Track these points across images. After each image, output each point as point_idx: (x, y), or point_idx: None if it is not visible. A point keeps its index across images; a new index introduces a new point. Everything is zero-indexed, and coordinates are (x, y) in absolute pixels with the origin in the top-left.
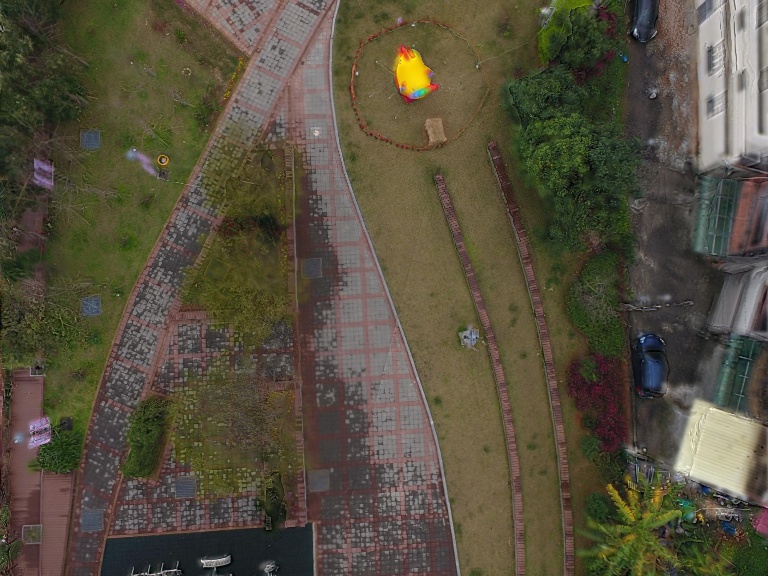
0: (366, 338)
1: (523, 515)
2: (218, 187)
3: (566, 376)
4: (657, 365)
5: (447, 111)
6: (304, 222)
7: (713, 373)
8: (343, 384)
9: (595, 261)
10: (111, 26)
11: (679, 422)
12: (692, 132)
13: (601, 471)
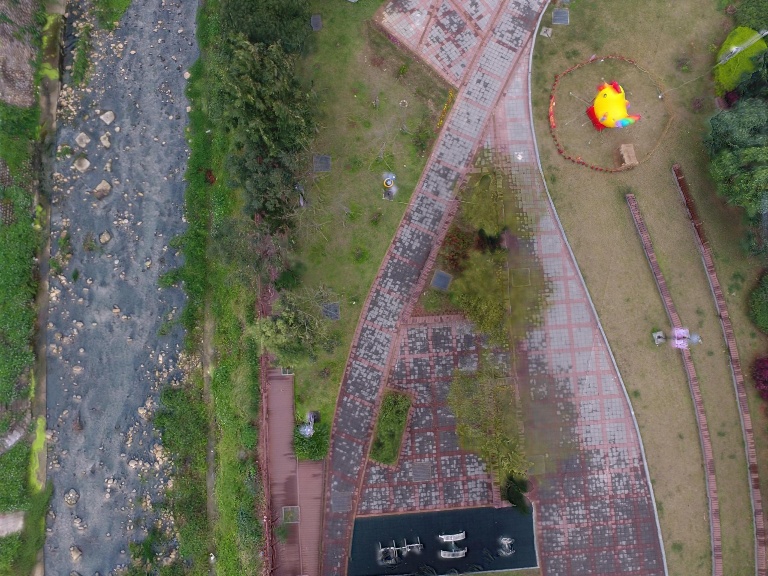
0: (571, 339)
1: (717, 494)
2: (436, 206)
3: (750, 371)
4: None
5: (635, 137)
6: (513, 237)
7: None
8: (553, 380)
9: None
10: (335, 64)
11: None
12: None
13: None
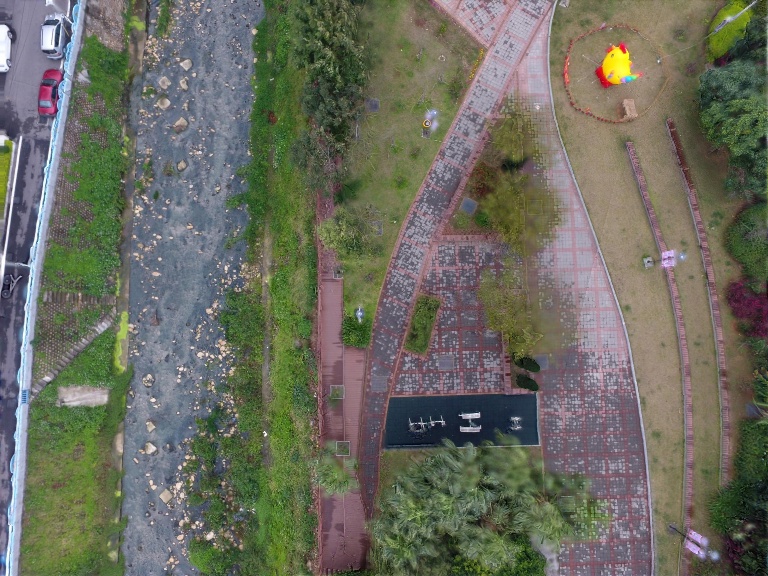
0: (575, 260)
1: (691, 391)
2: (466, 145)
3: (723, 292)
4: None
5: (636, 94)
6: (529, 173)
7: None
8: (558, 293)
9: (749, 207)
10: (385, 22)
11: None
12: None
13: (751, 360)
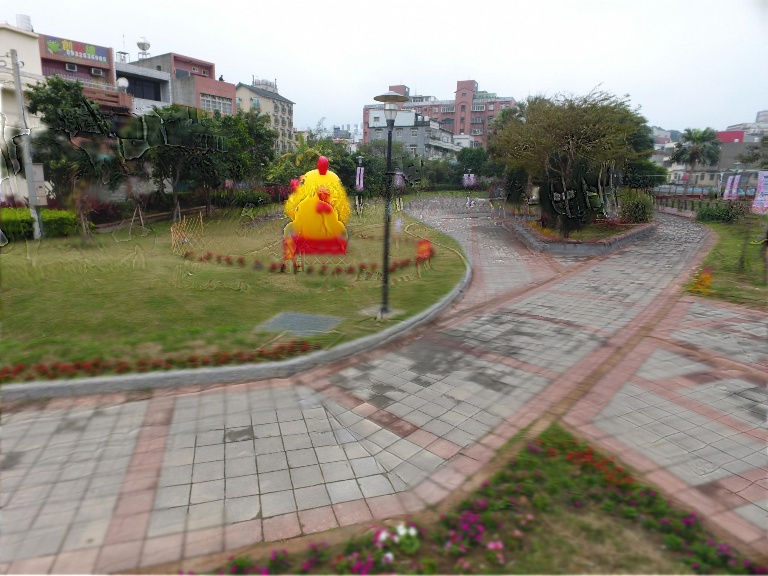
0: None
1: None
2: None
3: None
4: None
5: None
6: None
7: None
8: None
9: None
10: None
11: None
12: None
13: None
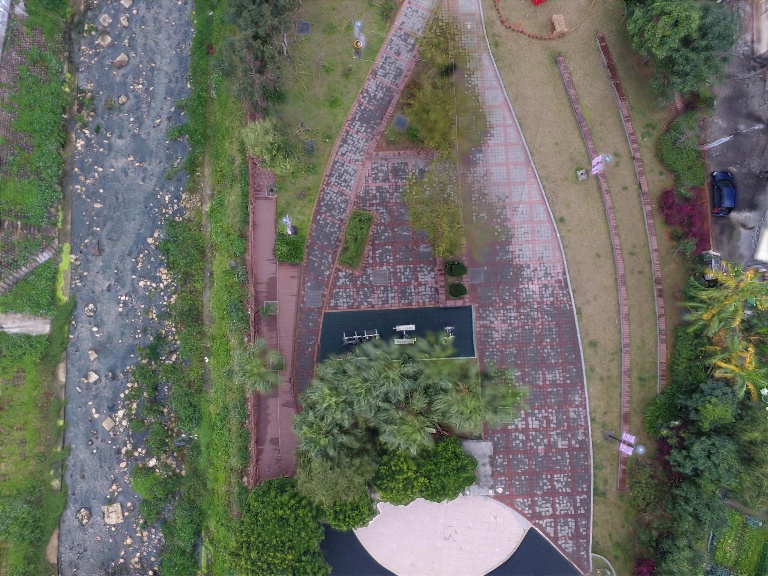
0: (508, 174)
1: (627, 300)
2: (398, 65)
3: (657, 202)
4: (727, 188)
5: (566, 11)
6: (461, 90)
7: (767, 199)
8: (492, 207)
9: (679, 116)
10: None
11: (742, 235)
12: (748, 28)
13: (685, 267)
